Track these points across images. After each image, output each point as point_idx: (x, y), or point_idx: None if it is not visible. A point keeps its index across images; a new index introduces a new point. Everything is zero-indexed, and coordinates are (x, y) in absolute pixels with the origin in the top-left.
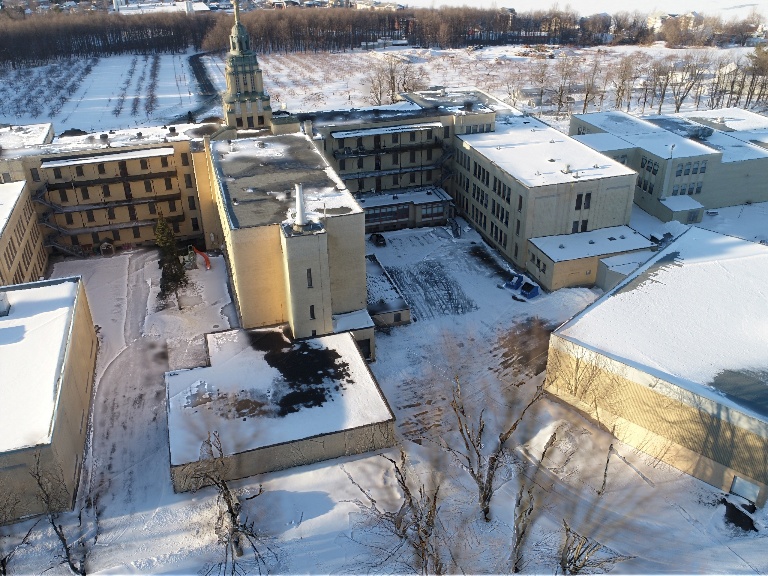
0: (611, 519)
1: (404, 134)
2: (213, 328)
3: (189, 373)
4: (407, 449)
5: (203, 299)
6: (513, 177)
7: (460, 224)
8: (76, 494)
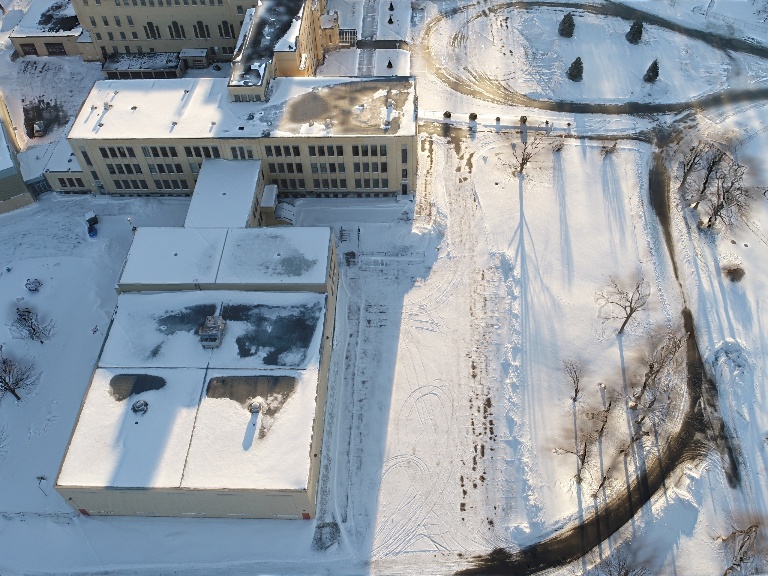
0: None
1: None
2: None
3: None
4: None
5: None
6: None
7: None
8: None
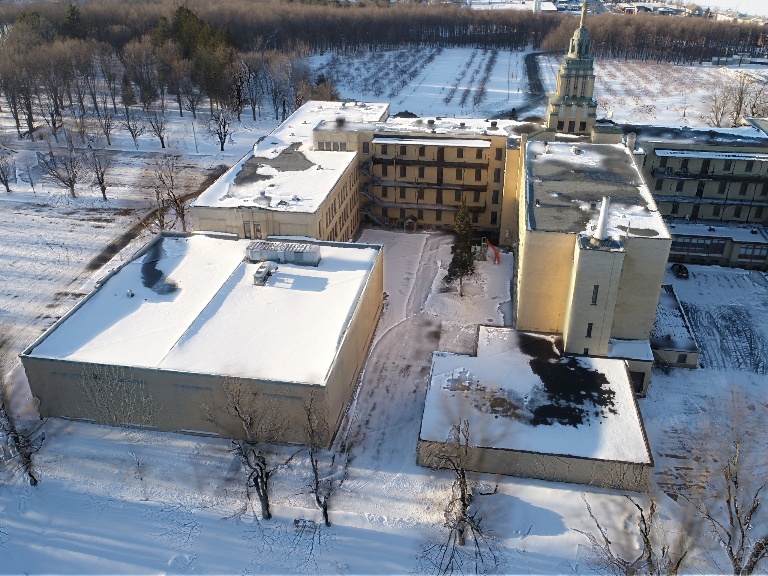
0: None
1: (739, 162)
2: (487, 321)
3: (455, 358)
4: (659, 500)
5: (484, 291)
6: None
7: None
8: (335, 437)
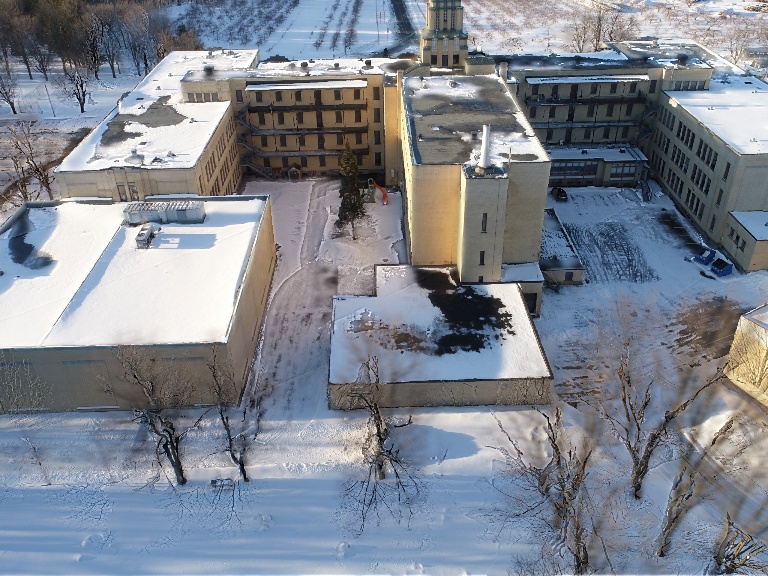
0: None
1: (604, 85)
2: (382, 261)
3: (355, 300)
4: None
5: (376, 232)
6: (723, 141)
7: (652, 188)
8: (243, 393)
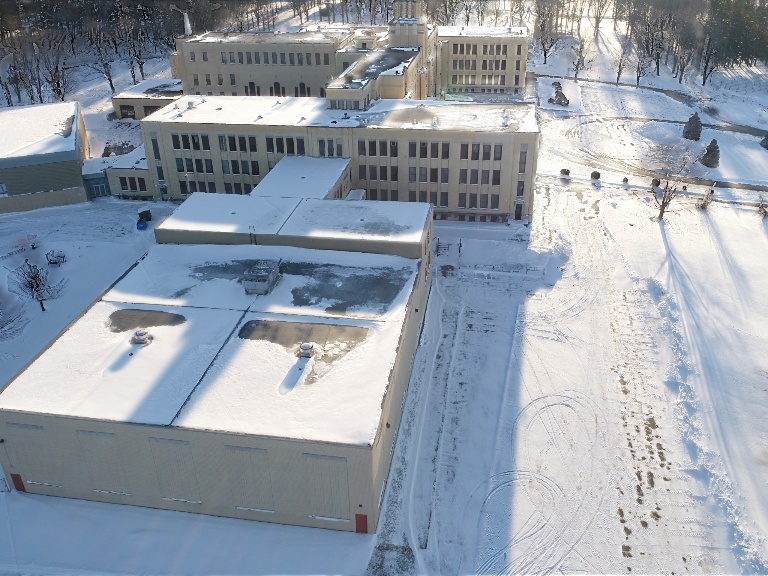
0: None
1: None
2: None
3: None
4: None
5: None
6: None
7: None
8: None
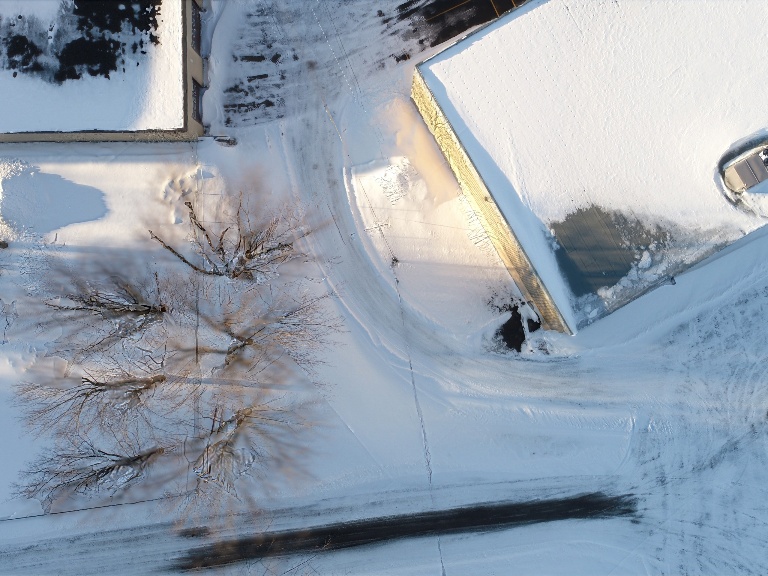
0: (387, 295)
1: None
2: None
3: None
4: (205, 153)
5: None
6: None
7: None
8: None
